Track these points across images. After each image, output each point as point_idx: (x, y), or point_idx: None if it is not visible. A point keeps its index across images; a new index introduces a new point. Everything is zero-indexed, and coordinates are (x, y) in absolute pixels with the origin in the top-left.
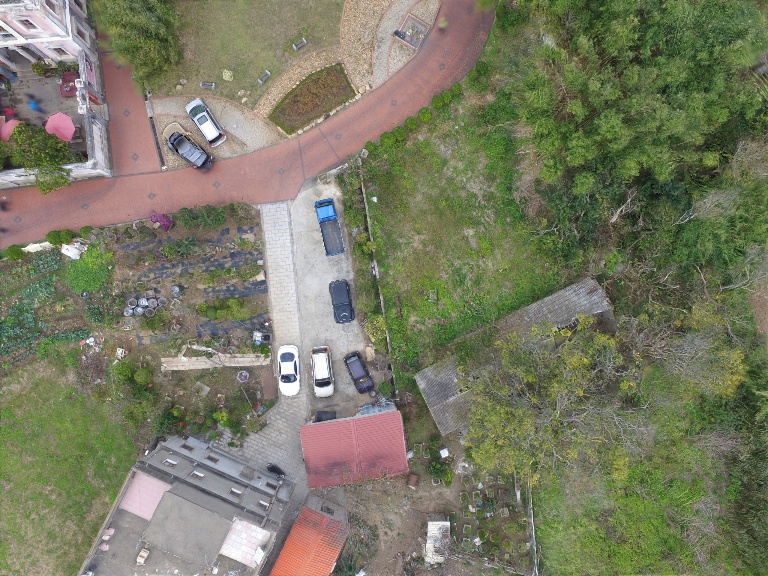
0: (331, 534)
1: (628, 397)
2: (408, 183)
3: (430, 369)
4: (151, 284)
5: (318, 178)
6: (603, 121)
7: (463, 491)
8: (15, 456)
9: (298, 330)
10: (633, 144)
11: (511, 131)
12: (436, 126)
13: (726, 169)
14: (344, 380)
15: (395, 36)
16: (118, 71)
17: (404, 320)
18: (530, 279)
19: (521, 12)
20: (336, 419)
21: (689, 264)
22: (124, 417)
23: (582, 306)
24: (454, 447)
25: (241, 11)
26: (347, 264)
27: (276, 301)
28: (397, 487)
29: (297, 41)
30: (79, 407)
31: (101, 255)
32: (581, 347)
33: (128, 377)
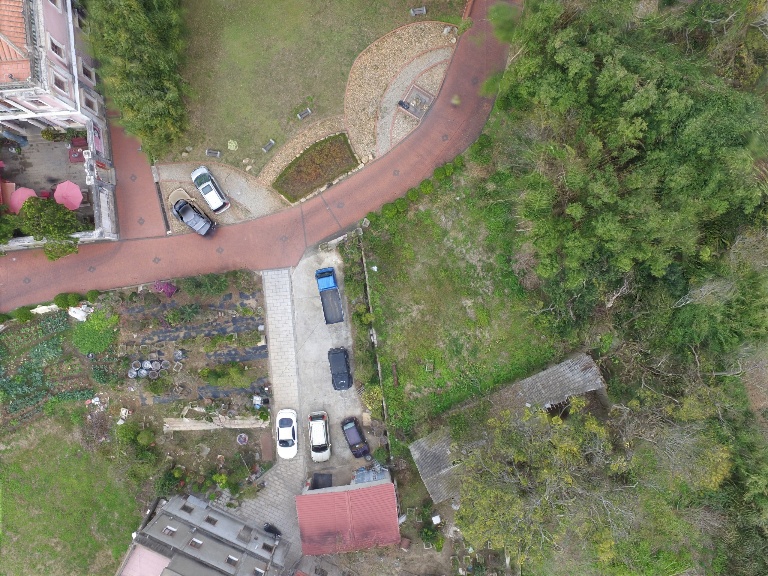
0: None
1: (618, 476)
2: (408, 253)
3: (424, 440)
4: (155, 347)
5: (319, 247)
6: (600, 224)
7: (454, 555)
8: (22, 509)
9: (297, 394)
10: (630, 239)
11: (512, 204)
12: (437, 197)
13: (724, 256)
14: (341, 444)
15: (399, 107)
16: (125, 136)
17: (401, 388)
18: (526, 351)
19: None
20: (331, 487)
21: (684, 344)
22: (127, 475)
23: (576, 383)
24: (446, 512)
25: (247, 79)
26: (346, 331)
27: (276, 366)
28: (390, 549)
29: (302, 110)
30: (84, 464)
31: None
32: (572, 434)
33: (131, 439)
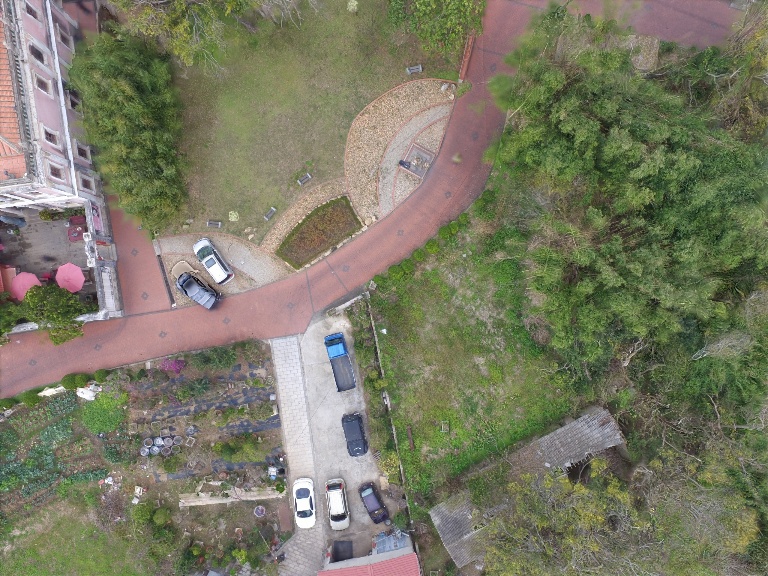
0: None
1: (643, 534)
2: (417, 314)
3: (444, 504)
4: (166, 423)
5: (327, 313)
6: (614, 296)
7: None
8: None
9: (312, 462)
10: None
11: (519, 258)
12: (444, 256)
13: (739, 307)
14: (359, 509)
15: (400, 166)
16: (124, 211)
17: (417, 451)
18: (542, 405)
19: (527, 139)
20: (353, 559)
21: (702, 394)
22: (145, 554)
23: (595, 439)
24: (470, 572)
25: (244, 148)
26: (359, 395)
27: (289, 434)
28: None
29: (302, 175)
30: (101, 545)
31: None
32: (595, 501)
33: (147, 519)
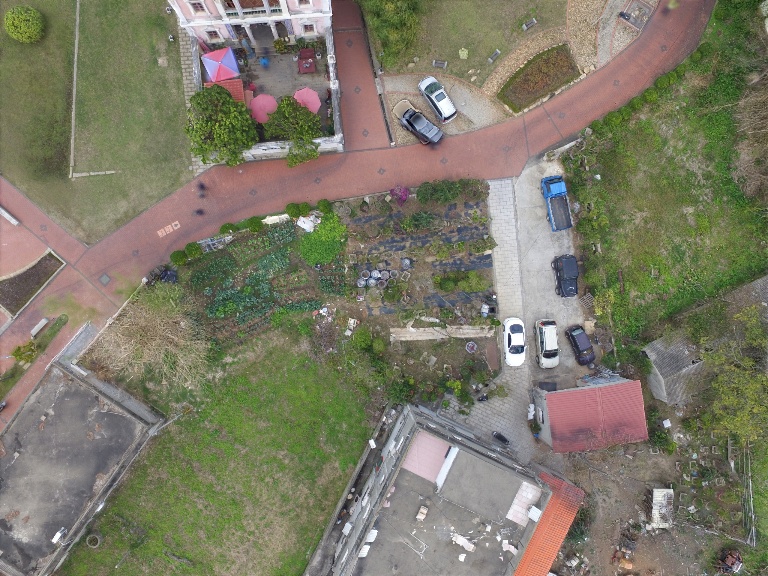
0: (568, 498)
1: None
2: (631, 161)
3: (659, 341)
4: (383, 257)
5: (546, 155)
6: None
7: (679, 461)
8: (250, 421)
9: (521, 303)
10: None
11: (731, 112)
12: (659, 106)
13: None
14: (564, 352)
15: (620, 17)
16: (350, 49)
17: (626, 294)
18: (746, 256)
19: None
20: (573, 388)
21: None
22: (356, 385)
23: None
24: None
25: None
26: (568, 240)
27: (500, 275)
28: (615, 456)
29: (526, 21)
30: (312, 375)
31: (334, 228)
32: None
33: (367, 346)
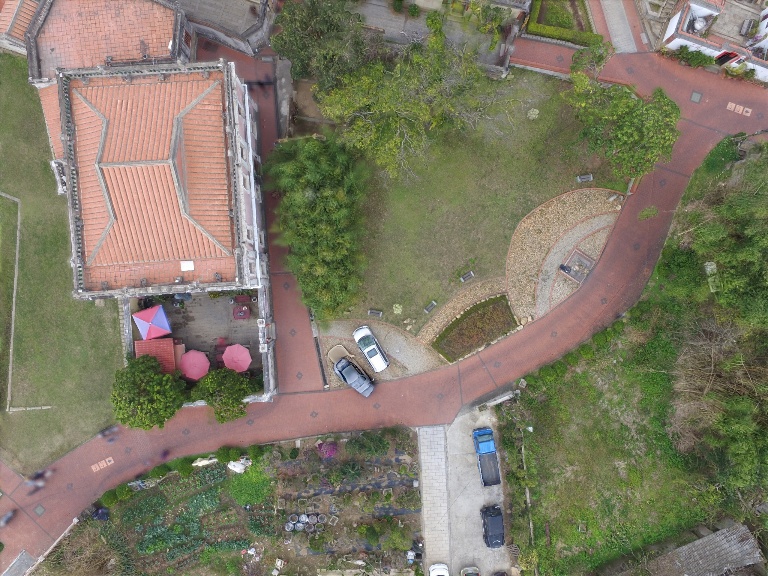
0: None
1: None
2: (564, 415)
3: None
4: (312, 501)
5: (478, 409)
6: None
7: None
8: None
9: (448, 548)
10: None
11: (669, 369)
12: (595, 361)
13: None
14: None
15: (560, 270)
16: (286, 291)
17: (553, 548)
18: (677, 512)
19: (689, 256)
20: None
21: None
22: None
23: (734, 555)
24: None
25: (411, 241)
26: (498, 487)
27: (429, 520)
28: None
29: (464, 272)
30: None
31: (264, 470)
32: None
33: None
